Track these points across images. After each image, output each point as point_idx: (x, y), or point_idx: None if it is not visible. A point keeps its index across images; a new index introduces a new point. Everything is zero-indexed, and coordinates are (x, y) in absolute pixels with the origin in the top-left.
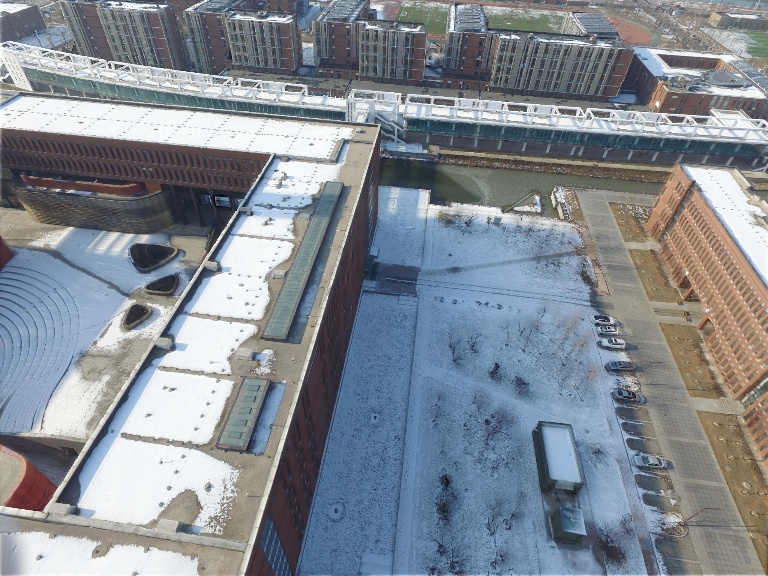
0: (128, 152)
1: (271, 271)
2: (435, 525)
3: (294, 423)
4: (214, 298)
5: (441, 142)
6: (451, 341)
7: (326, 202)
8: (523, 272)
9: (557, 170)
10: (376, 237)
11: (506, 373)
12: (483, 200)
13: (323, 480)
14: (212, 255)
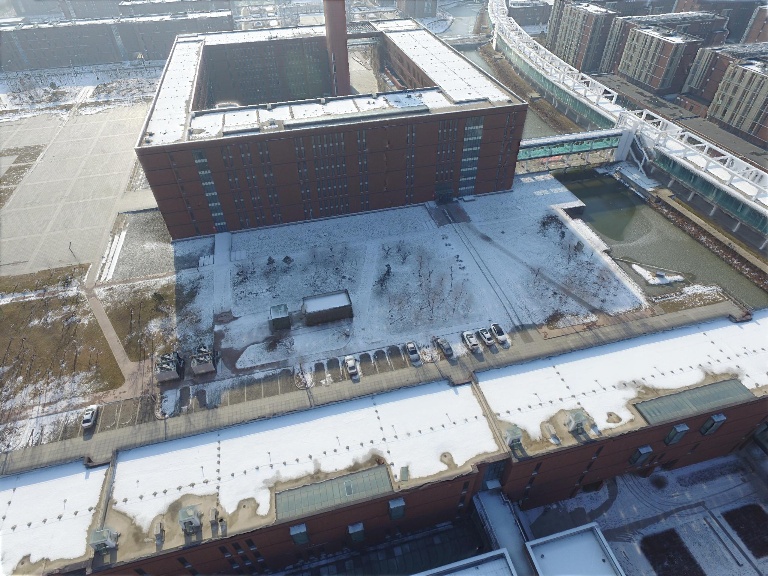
0: (408, 65)
1: (331, 113)
2: (266, 268)
3: (244, 143)
4: (303, 108)
5: (682, 193)
6: (400, 246)
7: (402, 109)
8: (521, 275)
9: (767, 286)
10: (488, 196)
11: (392, 280)
12: (621, 242)
13: (279, 228)
14: (331, 99)
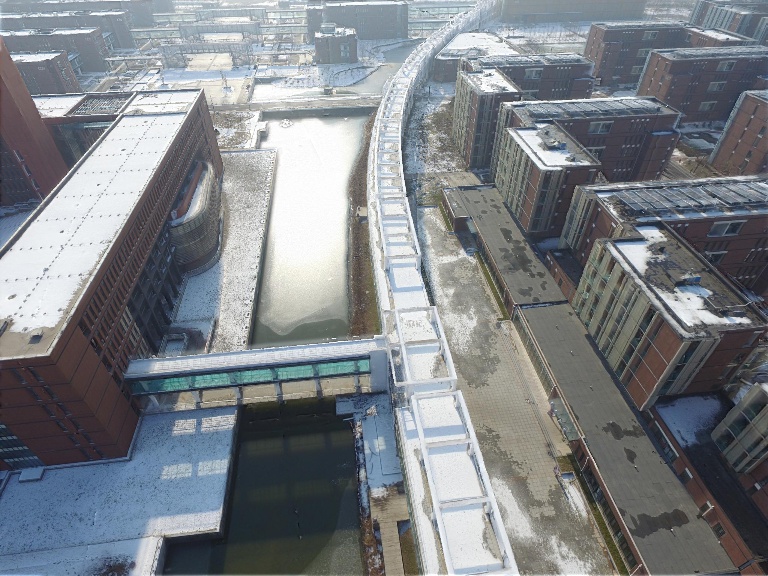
0: None
1: None
2: None
3: None
4: None
5: None
6: None
7: None
8: None
9: None
10: (77, 468)
11: None
12: None
13: None
14: None
